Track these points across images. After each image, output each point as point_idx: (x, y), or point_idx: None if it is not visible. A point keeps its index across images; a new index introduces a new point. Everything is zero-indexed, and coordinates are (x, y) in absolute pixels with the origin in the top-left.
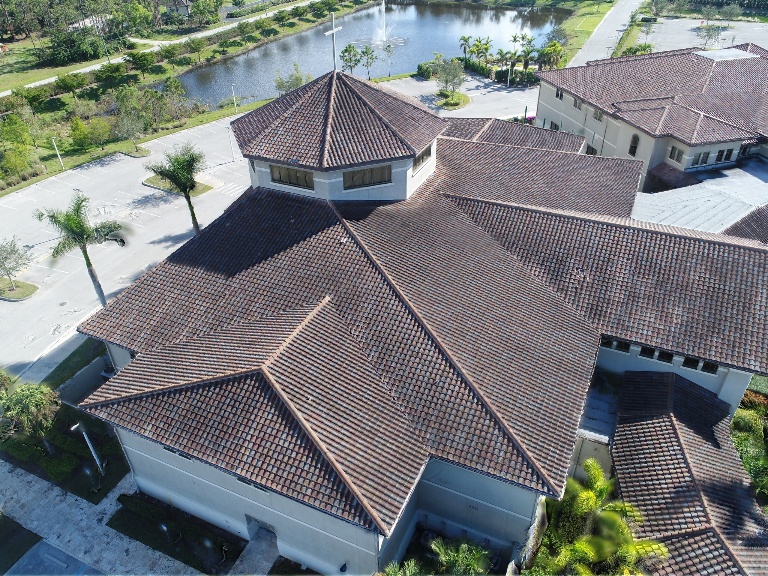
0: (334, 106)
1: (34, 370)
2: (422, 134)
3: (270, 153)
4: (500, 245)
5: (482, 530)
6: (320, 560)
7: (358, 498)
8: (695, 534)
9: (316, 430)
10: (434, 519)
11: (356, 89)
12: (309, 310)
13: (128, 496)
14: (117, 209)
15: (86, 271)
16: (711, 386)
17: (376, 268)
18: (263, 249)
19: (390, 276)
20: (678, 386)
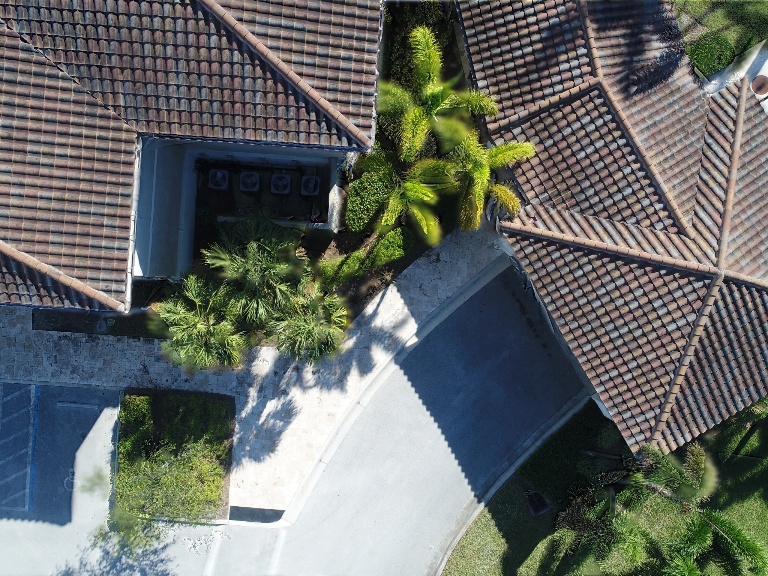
0: None
1: None
2: None
3: None
4: None
5: (284, 154)
6: None
7: (49, 276)
8: (573, 98)
9: None
10: (215, 155)
11: None
12: None
13: None
14: None
15: None
16: None
17: None
18: None
19: None
20: None
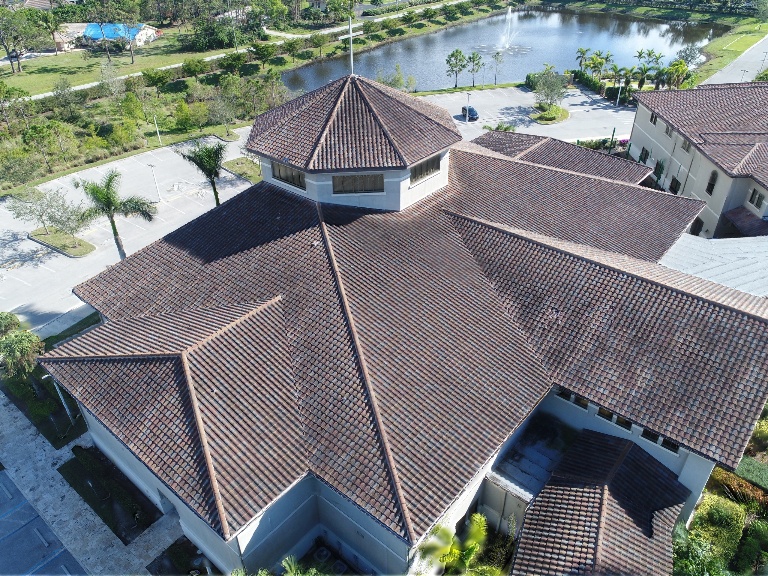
0: (339, 110)
1: (61, 321)
2: (423, 146)
3: (268, 150)
4: (482, 271)
5: (370, 560)
6: (208, 549)
7: (214, 496)
8: None
9: (206, 422)
10: (332, 537)
11: (367, 95)
12: (256, 306)
13: (80, 448)
14: (189, 187)
15: (139, 240)
16: (672, 465)
17: (333, 275)
18: (244, 241)
19: (343, 285)
20: (631, 457)
